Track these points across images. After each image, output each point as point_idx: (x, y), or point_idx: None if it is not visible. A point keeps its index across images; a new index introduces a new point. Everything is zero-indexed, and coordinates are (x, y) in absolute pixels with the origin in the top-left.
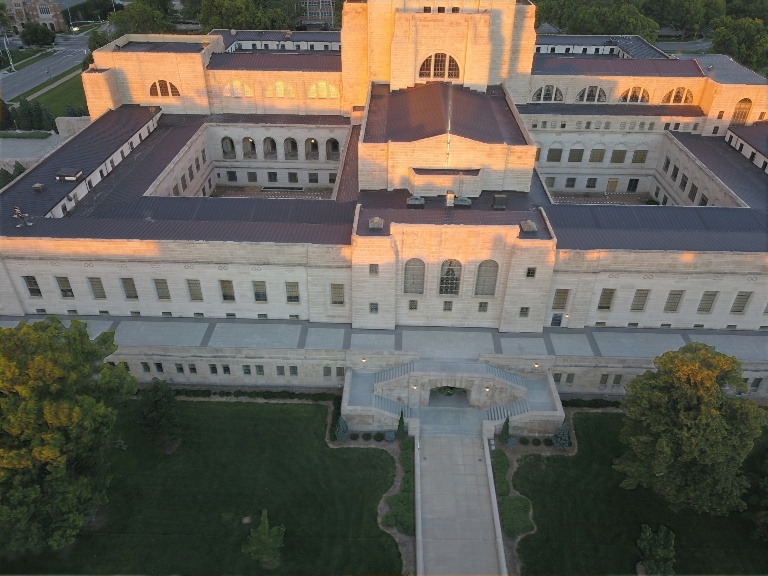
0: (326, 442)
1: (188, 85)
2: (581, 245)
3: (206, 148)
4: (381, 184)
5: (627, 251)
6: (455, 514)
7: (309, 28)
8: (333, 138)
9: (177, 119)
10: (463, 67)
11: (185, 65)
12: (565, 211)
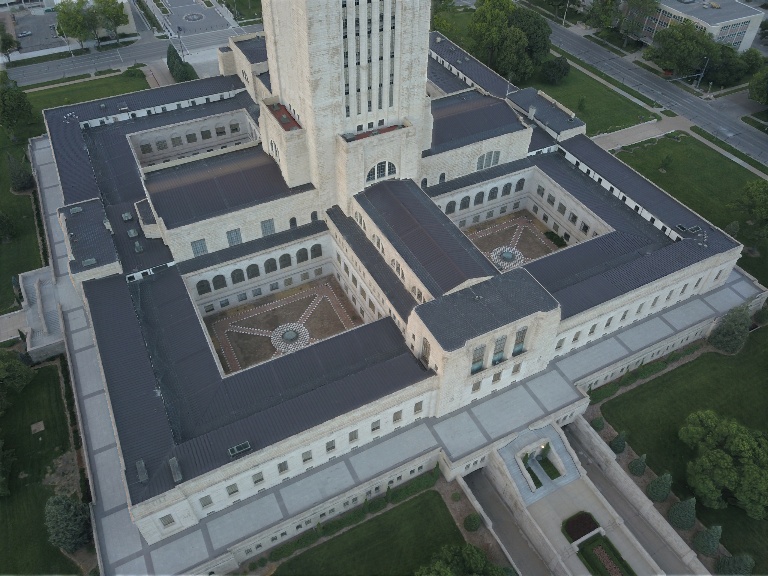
0: None
1: None
2: (98, 293)
3: (240, 124)
4: None
5: (88, 311)
6: None
7: (646, 47)
8: None
9: (245, 98)
10: None
11: None
12: (175, 284)
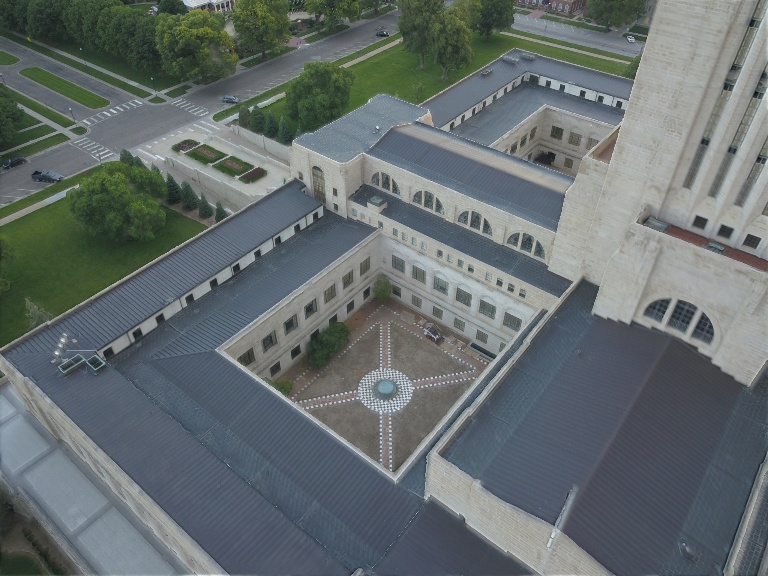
0: None
1: None
2: None
3: None
4: None
5: None
6: None
7: None
8: None
9: None
10: None
11: None
12: None
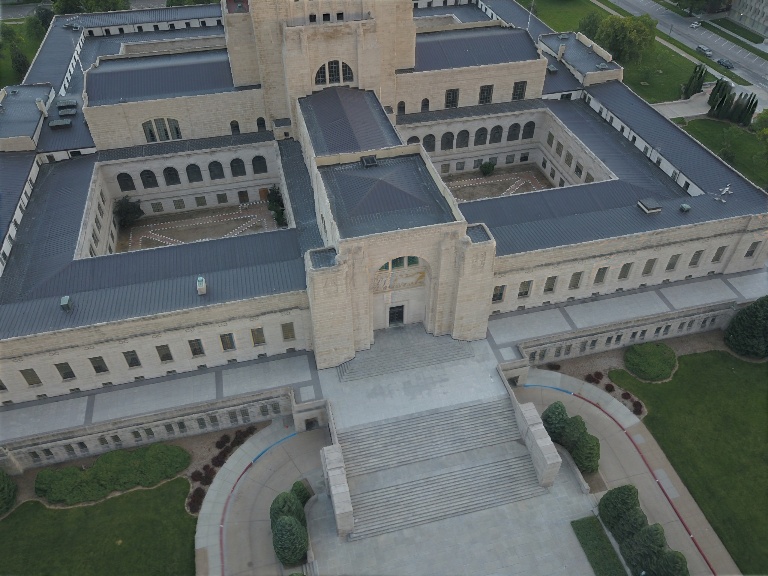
0: None
1: None
2: None
3: None
4: None
5: None
6: (664, 112)
7: None
8: None
9: None
10: None
11: None
12: None
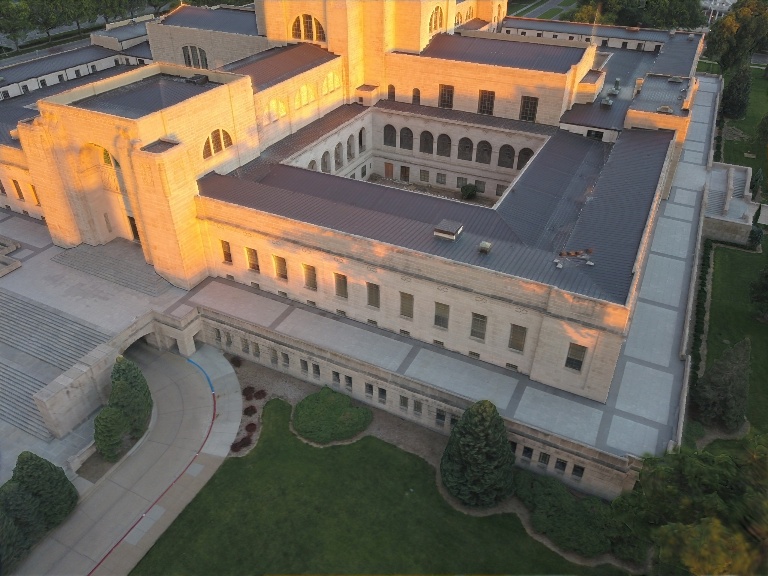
0: (757, 253)
1: (241, 125)
2: None
3: None
4: (565, 107)
5: None
6: None
7: None
8: (363, 127)
9: (242, 176)
10: (445, 16)
11: (237, 97)
12: None
